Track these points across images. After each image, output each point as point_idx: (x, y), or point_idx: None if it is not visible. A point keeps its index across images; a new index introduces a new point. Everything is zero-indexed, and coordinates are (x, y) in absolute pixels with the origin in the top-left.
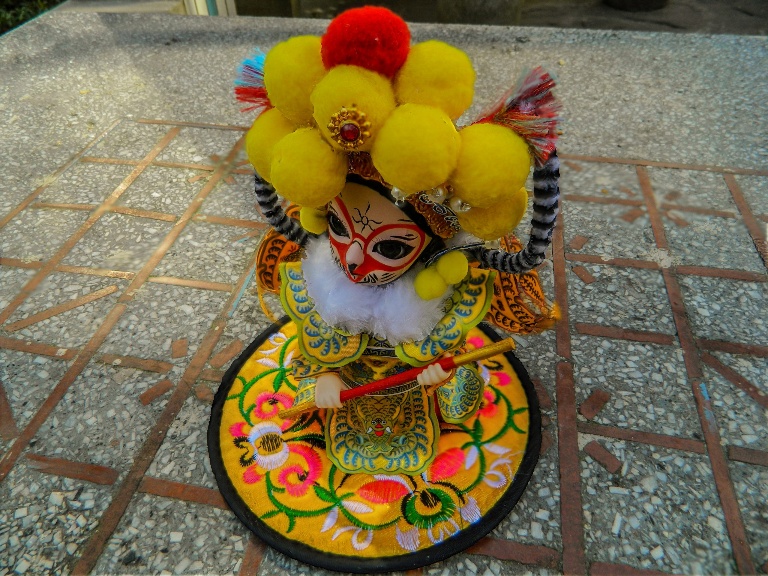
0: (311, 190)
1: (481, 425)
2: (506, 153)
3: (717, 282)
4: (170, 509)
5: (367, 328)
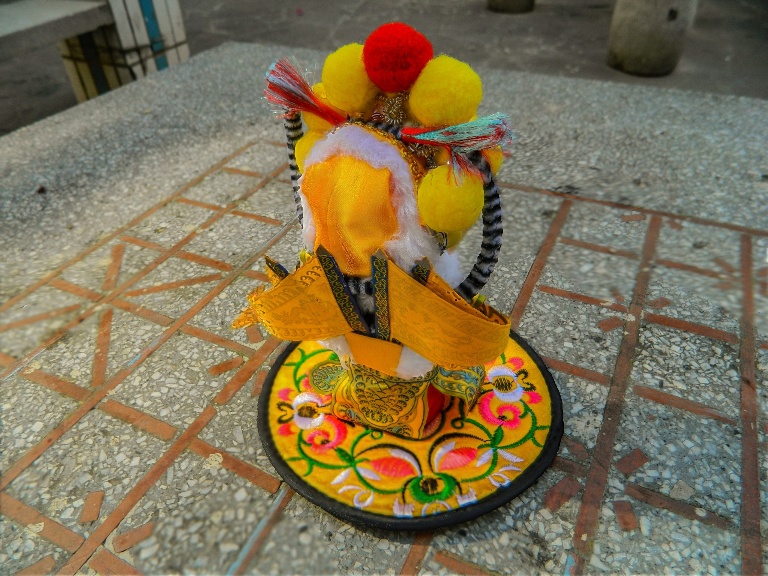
0: None
1: None
2: None
3: None
4: (579, 361)
5: None
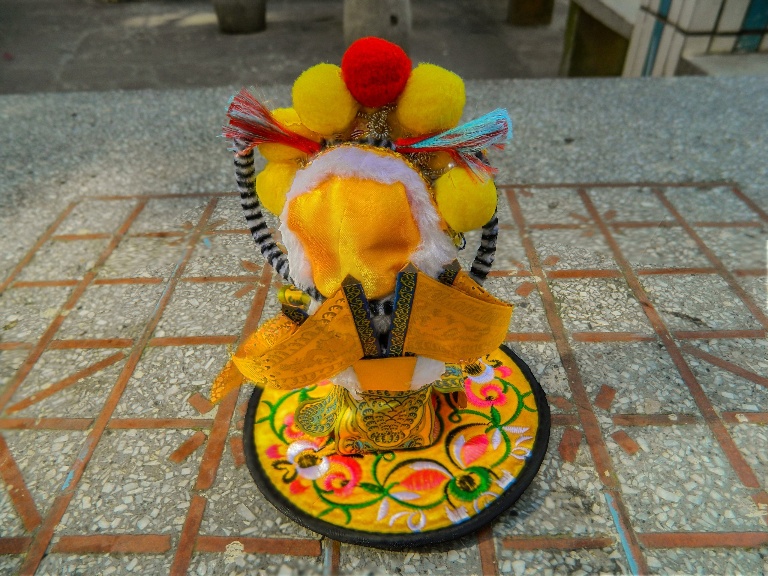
0: None
1: None
2: None
3: None
4: (519, 328)
5: None
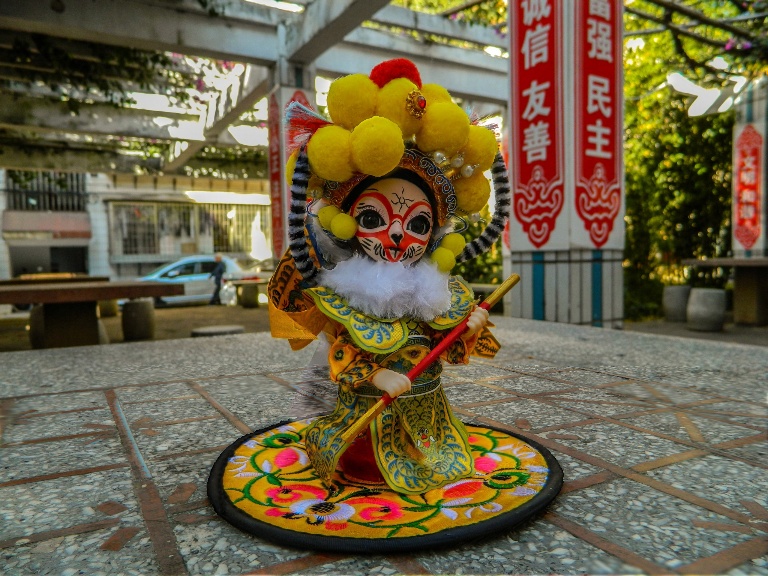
0: (398, 143)
1: (476, 445)
2: (489, 130)
3: (505, 380)
4: None
5: (408, 308)
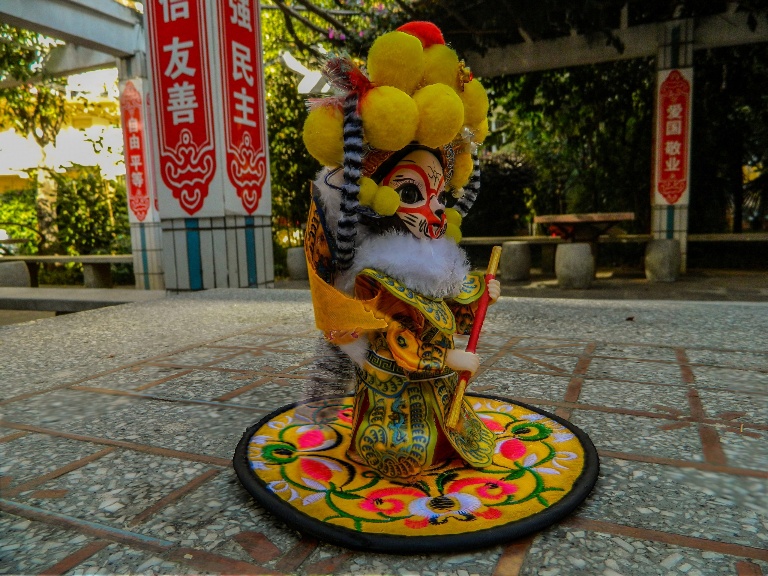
0: None
1: None
2: None
3: None
4: None
5: (447, 285)
